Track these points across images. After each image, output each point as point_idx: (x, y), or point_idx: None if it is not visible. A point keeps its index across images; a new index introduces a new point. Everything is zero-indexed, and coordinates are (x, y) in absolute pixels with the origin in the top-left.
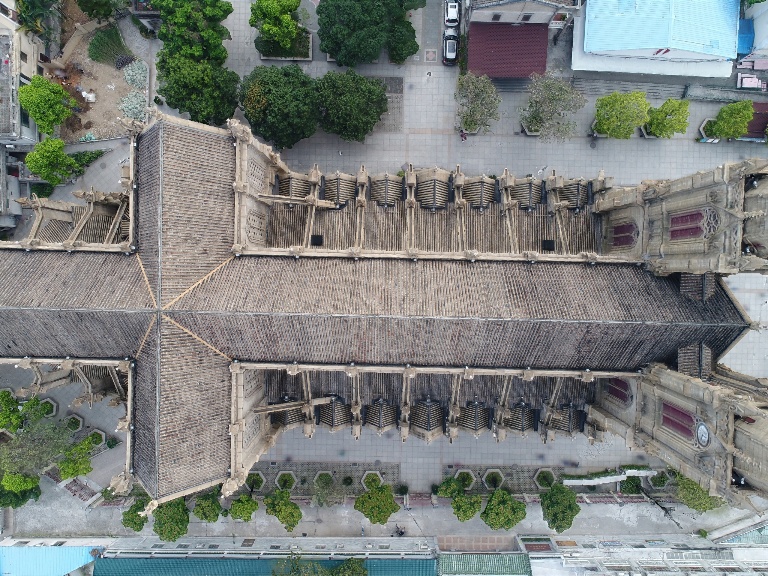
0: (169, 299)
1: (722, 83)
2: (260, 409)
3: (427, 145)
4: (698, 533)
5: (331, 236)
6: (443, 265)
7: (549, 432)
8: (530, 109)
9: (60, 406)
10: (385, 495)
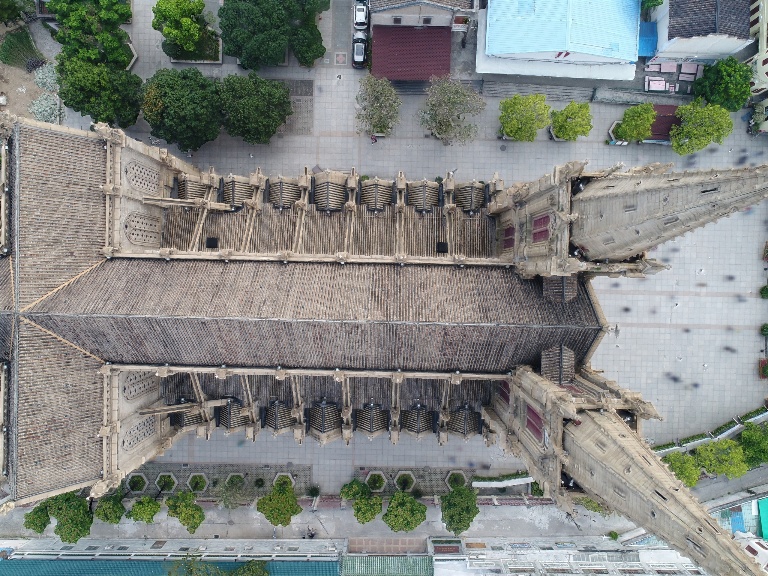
0: (28, 301)
1: (630, 86)
2: (147, 411)
3: (337, 148)
4: (609, 535)
5: (227, 238)
6: (313, 267)
7: (441, 434)
8: (430, 112)
9: None
10: (286, 497)
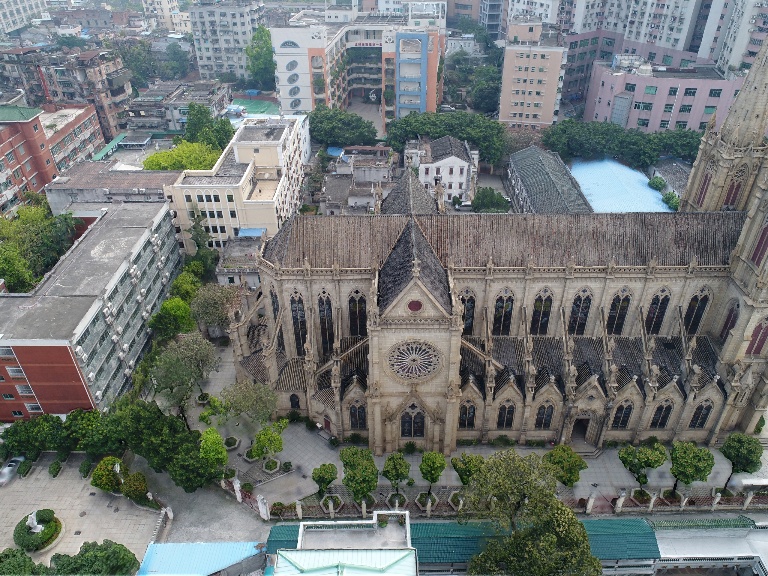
0: None
1: None
2: None
3: None
4: None
5: None
6: None
7: (694, 366)
8: None
9: (241, 443)
10: None
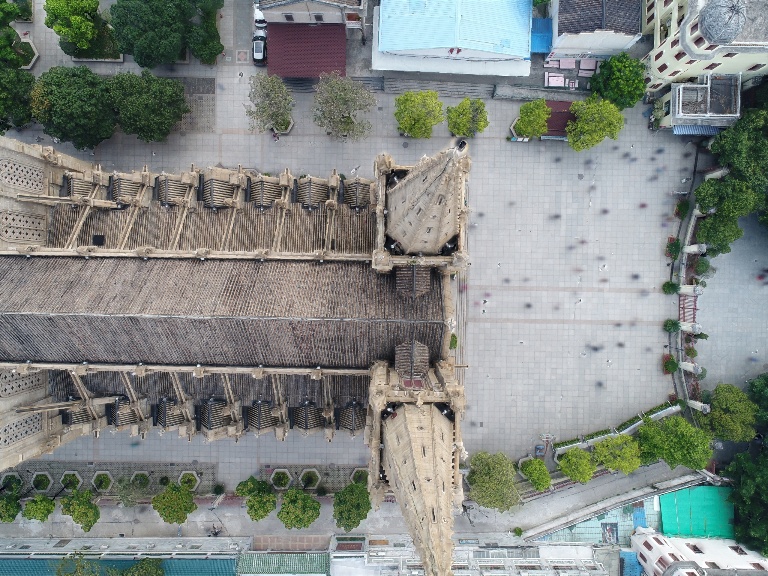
0: None
1: (530, 82)
2: (25, 409)
3: (240, 145)
4: (514, 532)
5: (113, 236)
6: (174, 264)
7: (325, 430)
8: (322, 109)
9: None
10: (179, 495)
